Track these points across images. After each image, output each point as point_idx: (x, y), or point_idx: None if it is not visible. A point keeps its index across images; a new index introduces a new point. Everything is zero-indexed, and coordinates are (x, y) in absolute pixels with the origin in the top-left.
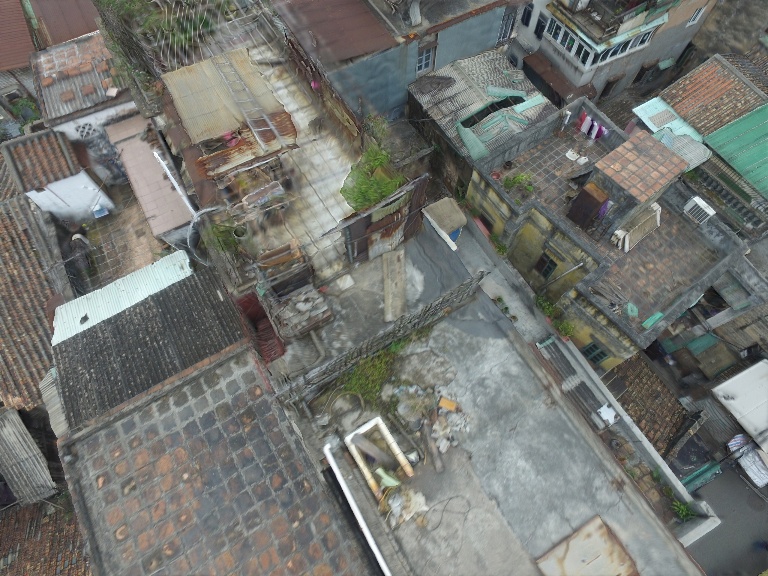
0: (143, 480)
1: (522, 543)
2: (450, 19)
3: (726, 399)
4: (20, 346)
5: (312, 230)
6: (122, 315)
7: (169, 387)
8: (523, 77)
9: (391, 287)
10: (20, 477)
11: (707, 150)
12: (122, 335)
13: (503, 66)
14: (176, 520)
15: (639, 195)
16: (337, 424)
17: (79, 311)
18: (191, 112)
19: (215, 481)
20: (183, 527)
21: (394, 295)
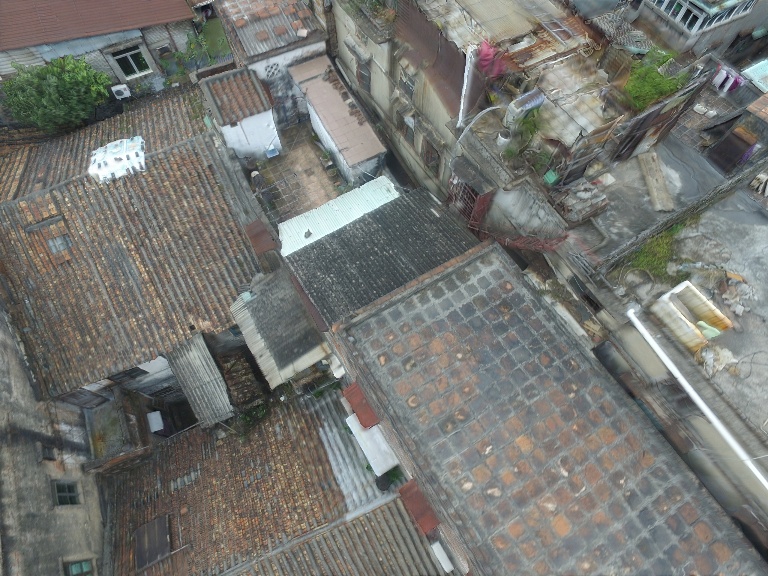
0: (421, 359)
1: None
2: None
3: None
4: (208, 273)
5: (563, 136)
6: (344, 230)
7: (429, 280)
8: (644, 37)
9: (653, 182)
10: (202, 399)
11: None
12: (350, 246)
13: (624, 27)
14: (460, 391)
15: None
16: (633, 294)
17: (301, 227)
18: (484, 17)
19: (488, 360)
20: (469, 397)
21: (658, 189)
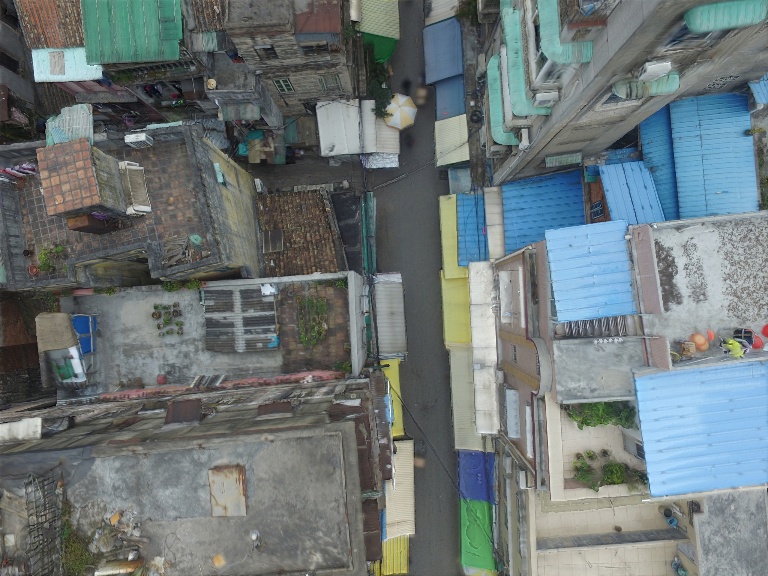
0: None
1: (203, 516)
2: None
3: (332, 151)
4: None
5: None
6: None
7: None
8: None
9: None
10: None
11: (84, 107)
12: None
13: None
14: None
15: (91, 201)
16: None
17: None
18: None
19: None
20: None
21: None
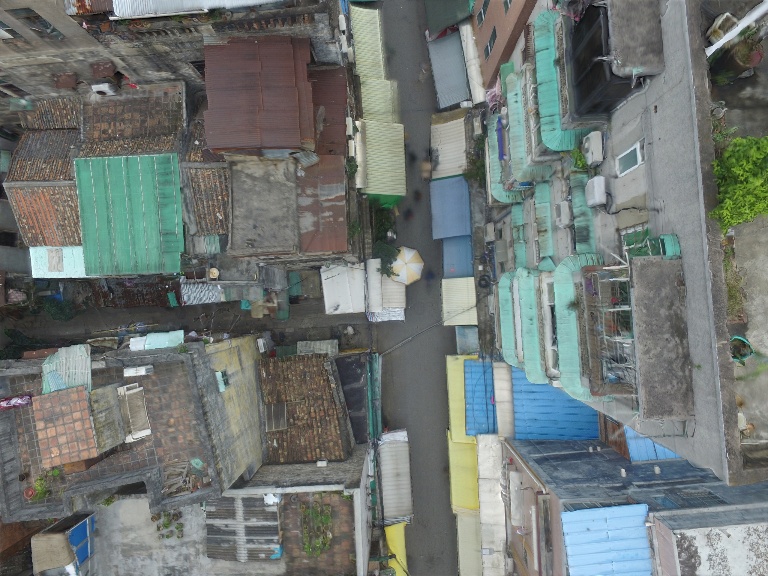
0: None
1: None
2: None
3: (336, 310)
4: None
5: None
6: None
7: None
8: None
9: None
10: None
11: (81, 348)
12: None
13: None
14: None
15: (89, 454)
16: None
17: None
18: None
19: None
20: None
21: None
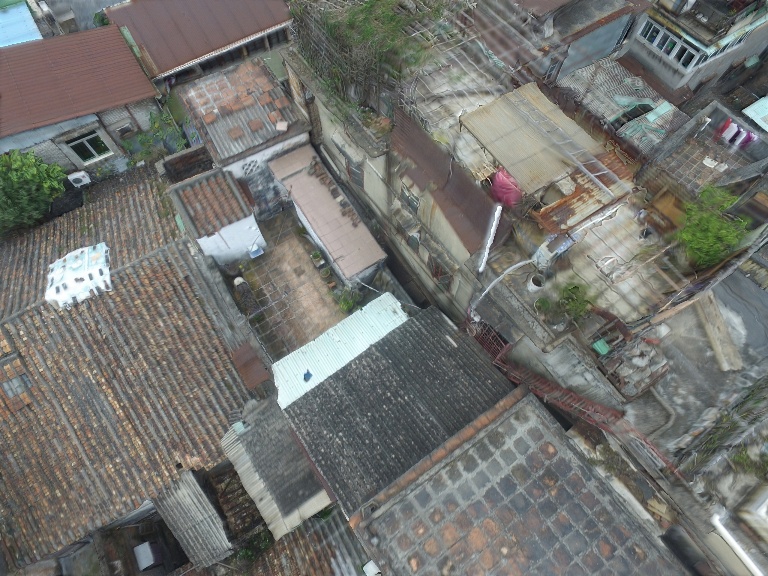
0: (460, 559)
1: None
2: (581, 29)
3: None
4: (193, 402)
5: None
6: (349, 369)
7: (459, 452)
8: (643, 84)
9: (714, 332)
10: (196, 541)
11: None
12: (358, 392)
13: (621, 73)
14: None
15: None
16: (714, 490)
17: (299, 367)
18: (511, 158)
19: (538, 554)
20: None
21: (721, 341)
